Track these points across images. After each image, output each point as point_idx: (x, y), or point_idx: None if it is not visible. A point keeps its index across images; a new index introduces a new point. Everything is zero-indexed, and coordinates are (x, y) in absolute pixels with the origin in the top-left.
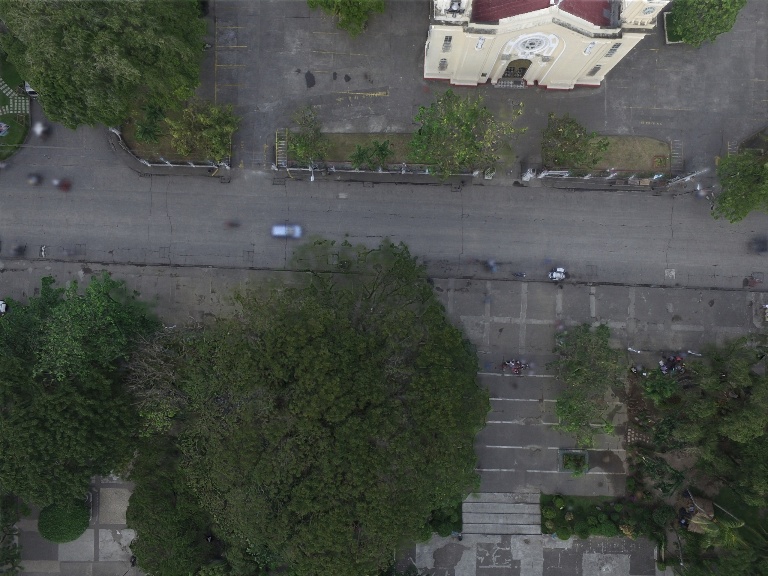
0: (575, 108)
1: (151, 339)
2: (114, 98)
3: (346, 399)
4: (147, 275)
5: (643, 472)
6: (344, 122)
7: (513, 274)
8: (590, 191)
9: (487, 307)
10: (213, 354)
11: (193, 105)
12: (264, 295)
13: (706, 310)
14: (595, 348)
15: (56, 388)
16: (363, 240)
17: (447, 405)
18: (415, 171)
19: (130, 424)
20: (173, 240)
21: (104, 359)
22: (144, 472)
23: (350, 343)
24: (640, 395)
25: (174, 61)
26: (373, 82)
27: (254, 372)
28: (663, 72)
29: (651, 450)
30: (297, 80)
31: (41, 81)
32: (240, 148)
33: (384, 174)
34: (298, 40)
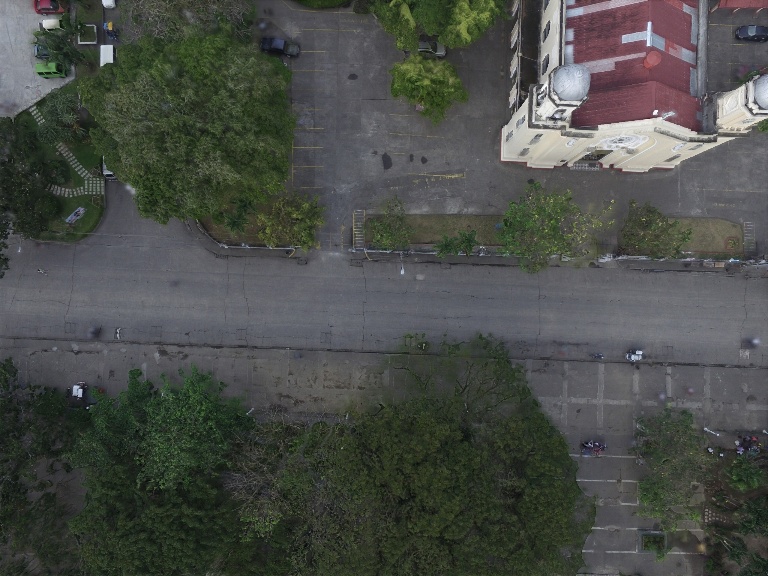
0: (649, 190)
1: (245, 437)
2: (212, 199)
3: (464, 517)
4: (224, 357)
5: (722, 553)
6: (421, 204)
7: (590, 355)
8: (665, 272)
9: (564, 388)
10: (319, 463)
11: (283, 199)
12: (342, 377)
13: None
14: (682, 438)
15: (158, 496)
16: (441, 321)
17: (561, 518)
18: (493, 253)
19: (231, 530)
20: (250, 322)
21: (206, 465)
22: (234, 568)
23: (465, 458)
24: (717, 475)
25: (268, 158)
26: (450, 164)
27: (371, 489)
28: (735, 155)
29: (729, 530)
30: (374, 162)
31: (141, 184)
32: (317, 230)
33: (461, 256)
34: (375, 122)
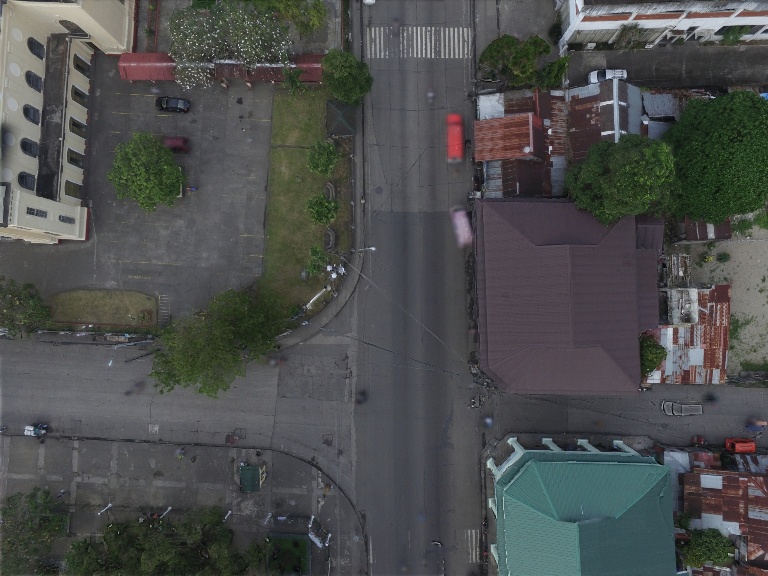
0: (64, 261)
1: None
2: None
3: None
4: None
5: None
6: None
7: None
8: (77, 344)
9: None
10: None
11: None
12: None
13: (188, 466)
14: (8, 523)
15: None
16: None
17: None
18: None
19: None
20: None
21: None
22: None
23: None
24: None
25: None
26: None
27: None
28: (153, 226)
29: None
30: None
31: None
32: None
33: None
34: None
